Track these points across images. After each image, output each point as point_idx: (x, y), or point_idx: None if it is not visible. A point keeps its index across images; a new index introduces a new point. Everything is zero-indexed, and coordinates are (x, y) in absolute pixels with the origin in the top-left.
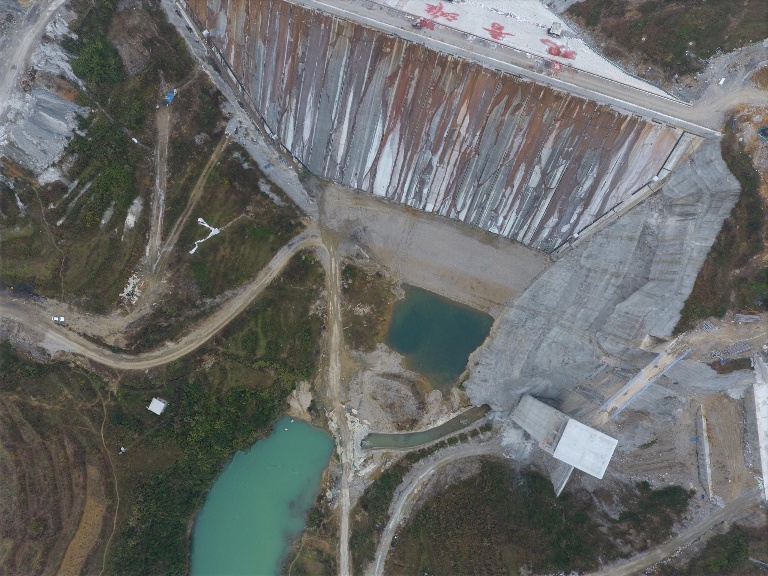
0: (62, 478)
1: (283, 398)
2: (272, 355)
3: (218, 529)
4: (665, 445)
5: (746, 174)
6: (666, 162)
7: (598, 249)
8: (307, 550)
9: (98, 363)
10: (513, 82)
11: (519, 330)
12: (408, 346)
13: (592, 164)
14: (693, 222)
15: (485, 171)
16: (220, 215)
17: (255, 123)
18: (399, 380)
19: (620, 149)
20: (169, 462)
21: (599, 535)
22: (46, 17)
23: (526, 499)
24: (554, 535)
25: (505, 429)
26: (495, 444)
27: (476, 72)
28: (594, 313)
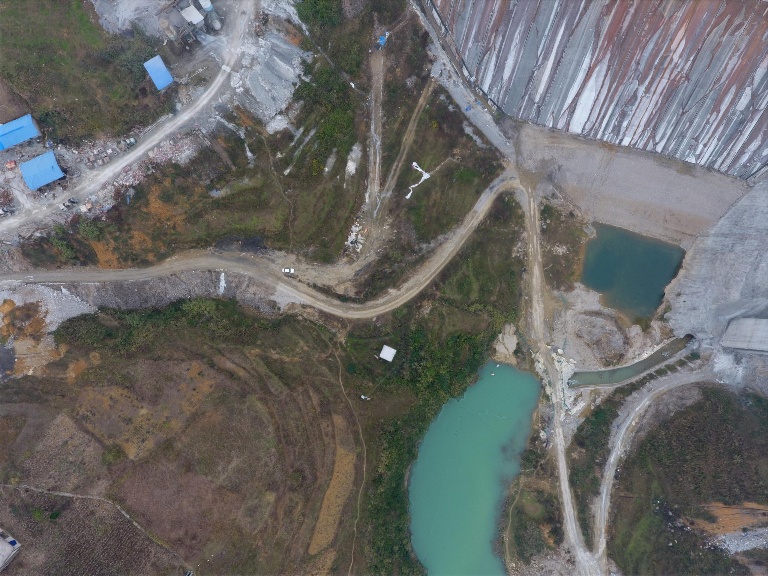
0: (313, 428)
1: (490, 343)
2: (485, 298)
3: (431, 480)
4: None
5: None
6: None
7: None
8: (525, 492)
9: (328, 313)
10: (738, 0)
11: (727, 255)
12: (603, 284)
13: None
14: None
15: (692, 97)
16: (431, 159)
17: (454, 66)
18: (602, 317)
19: None
20: (405, 408)
21: None
22: None
23: (759, 417)
24: None
25: (716, 355)
26: (708, 371)
27: None
28: None
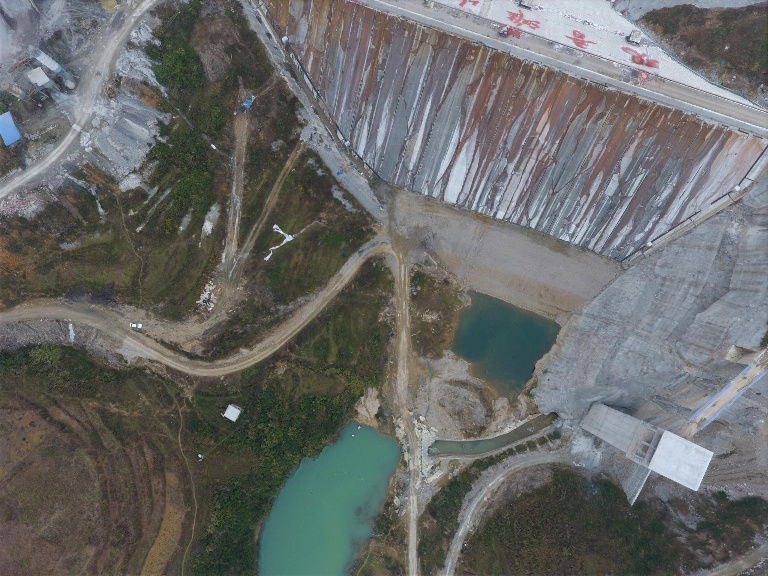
0: (142, 485)
1: (351, 405)
2: (343, 362)
3: (284, 535)
4: (745, 455)
5: None
6: (749, 172)
7: (674, 258)
8: (374, 557)
9: (174, 370)
10: (598, 91)
11: (591, 338)
12: (474, 353)
13: (672, 173)
14: None
15: (561, 179)
16: (294, 222)
17: (328, 129)
18: (467, 387)
19: (703, 158)
20: (245, 469)
21: (678, 545)
22: (131, 23)
23: (601, 508)
24: (632, 545)
25: (575, 437)
26: (565, 452)
27: (561, 81)
28: (673, 323)
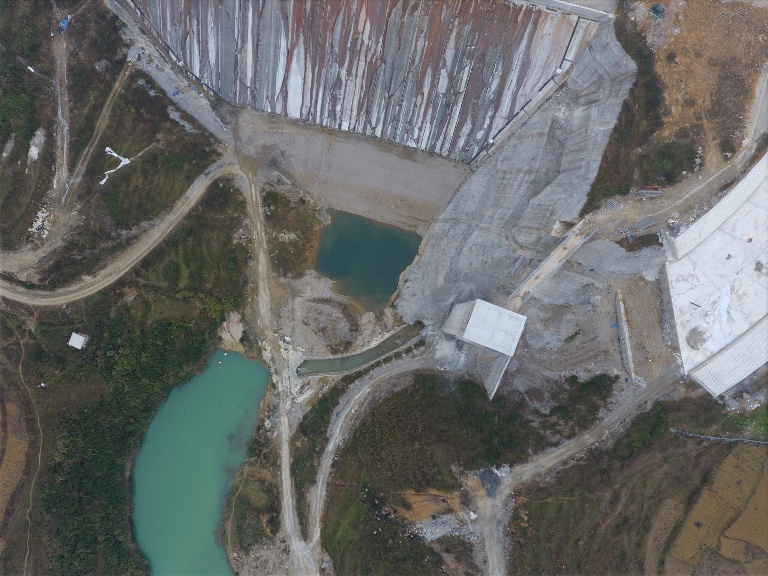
0: None
1: (214, 331)
2: (196, 285)
3: (159, 470)
4: (588, 335)
5: (640, 52)
6: (566, 52)
7: (512, 151)
8: (250, 481)
9: (12, 300)
10: None
11: (442, 240)
12: (338, 271)
13: (496, 62)
14: (596, 108)
15: (393, 80)
16: (129, 144)
17: (159, 50)
18: (330, 304)
19: (520, 43)
20: (94, 396)
21: (530, 429)
22: None
23: (458, 403)
24: (486, 434)
25: (438, 342)
26: (429, 357)
27: None
28: (509, 210)
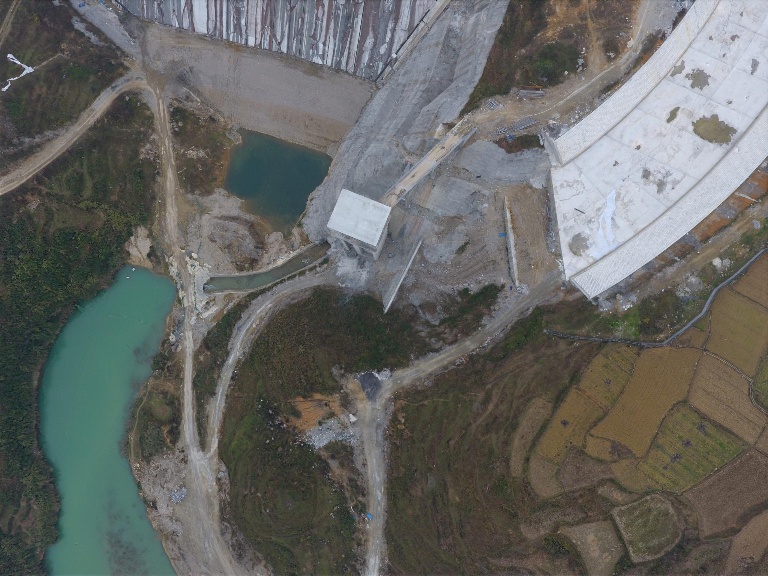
0: None
1: (121, 245)
2: (100, 196)
3: (67, 382)
4: (477, 245)
5: None
6: None
7: (412, 64)
8: (154, 394)
9: None
10: None
11: (344, 155)
12: (248, 191)
13: None
14: (485, 12)
15: None
16: (32, 52)
17: None
18: (237, 221)
19: None
20: None
21: (416, 338)
22: None
23: (350, 314)
24: (373, 341)
25: (340, 259)
26: (330, 274)
27: None
28: (402, 119)
